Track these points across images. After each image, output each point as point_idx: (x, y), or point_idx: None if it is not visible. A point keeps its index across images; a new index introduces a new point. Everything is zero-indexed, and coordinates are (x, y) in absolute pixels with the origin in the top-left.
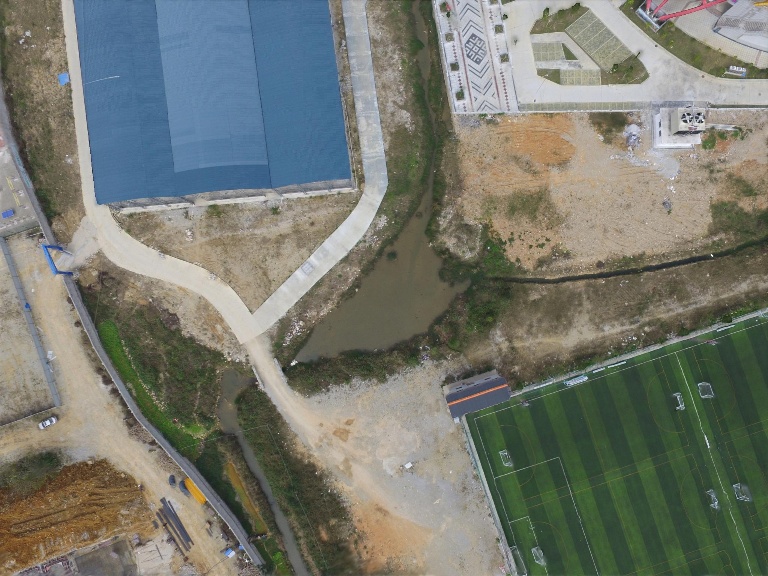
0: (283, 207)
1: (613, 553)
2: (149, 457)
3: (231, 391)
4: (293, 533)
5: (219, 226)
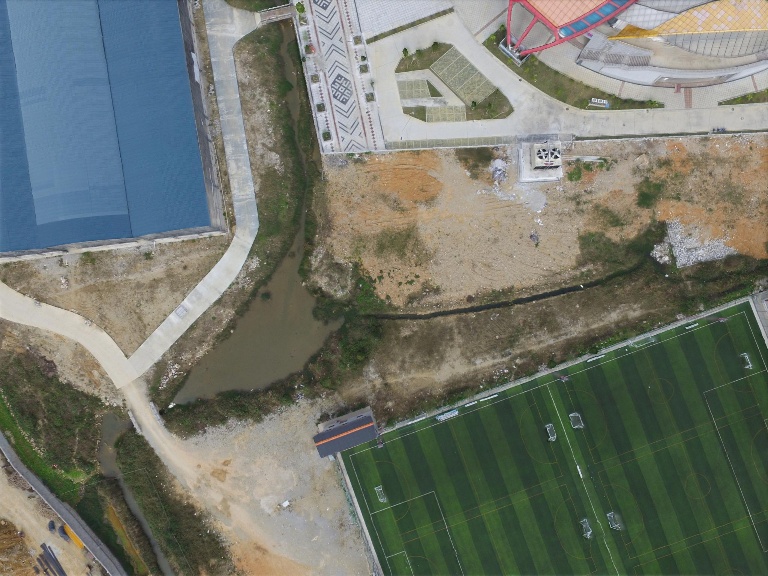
0: (156, 252)
1: None
2: (29, 504)
3: (111, 435)
4: (174, 574)
5: (93, 273)
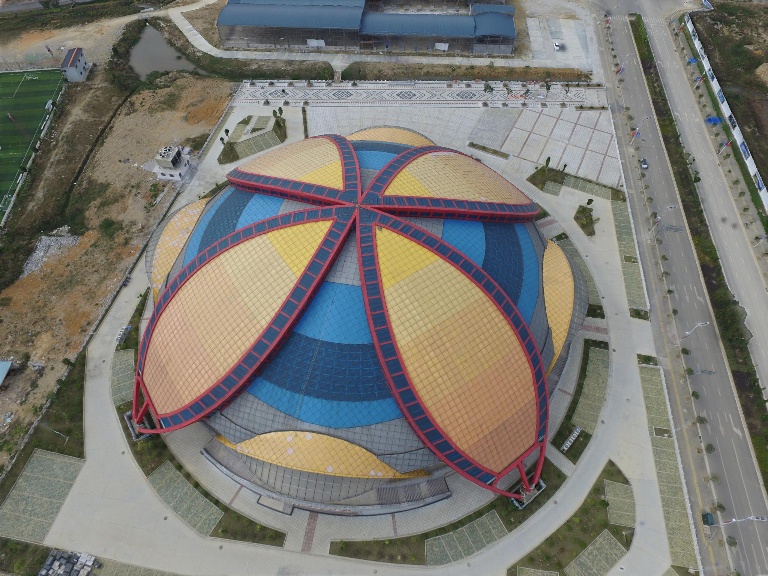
0: None
1: None
2: None
3: None
4: None
5: None
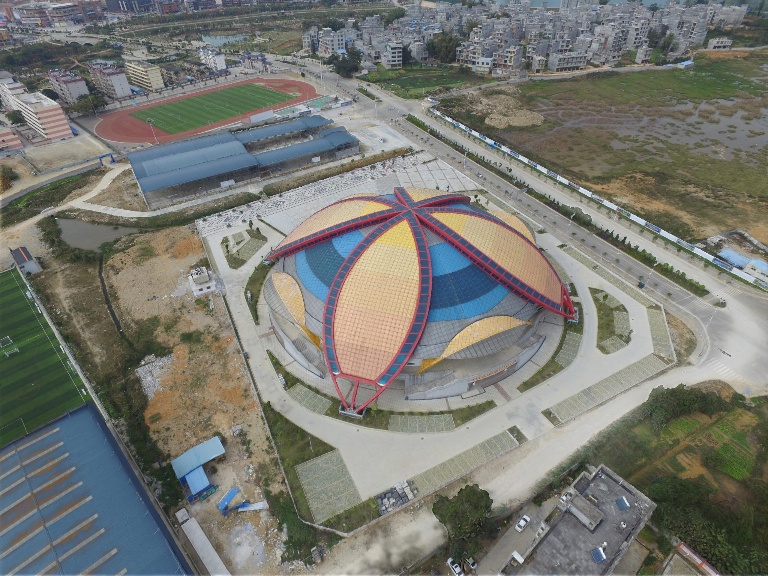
0: None
1: None
2: None
3: None
4: None
5: None
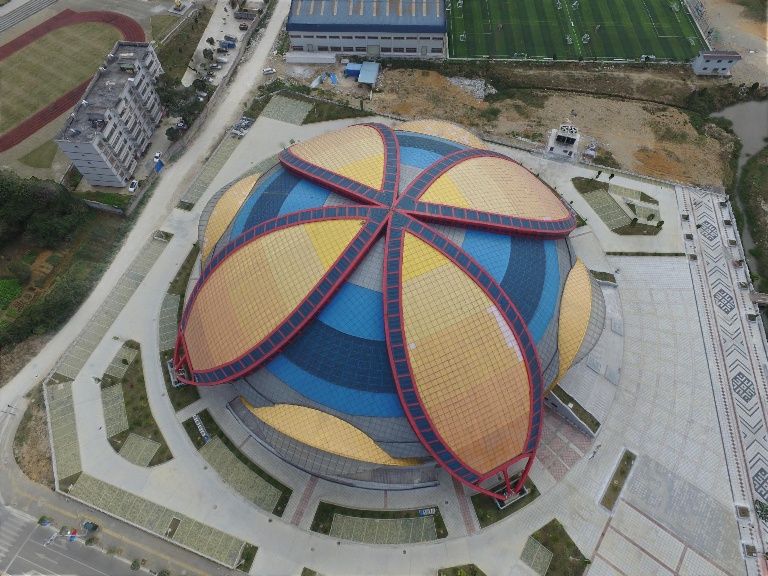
0: None
1: (633, 2)
2: None
3: None
4: None
5: None
